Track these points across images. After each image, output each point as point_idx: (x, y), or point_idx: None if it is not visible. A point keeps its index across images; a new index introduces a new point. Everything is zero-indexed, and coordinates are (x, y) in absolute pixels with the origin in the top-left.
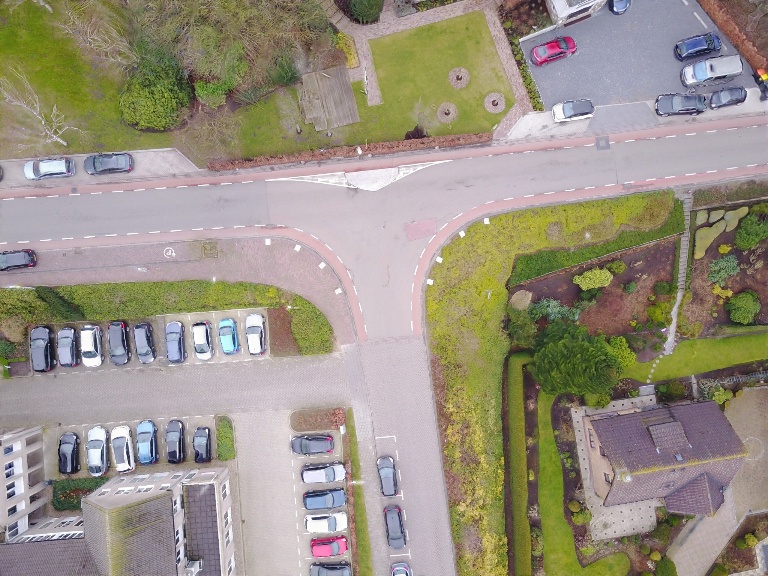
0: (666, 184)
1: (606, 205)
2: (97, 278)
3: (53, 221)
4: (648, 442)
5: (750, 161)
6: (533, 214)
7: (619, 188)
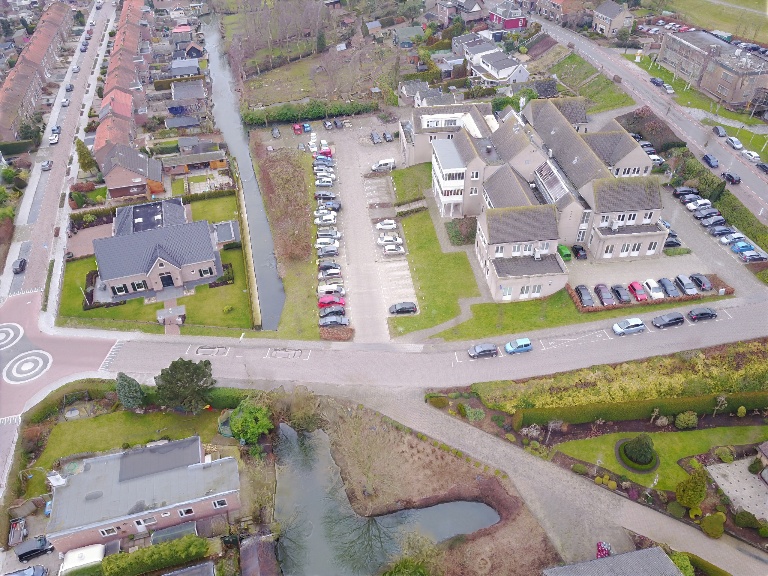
0: None
1: None
2: (742, 201)
3: (760, 188)
4: None
5: None
6: None
7: None
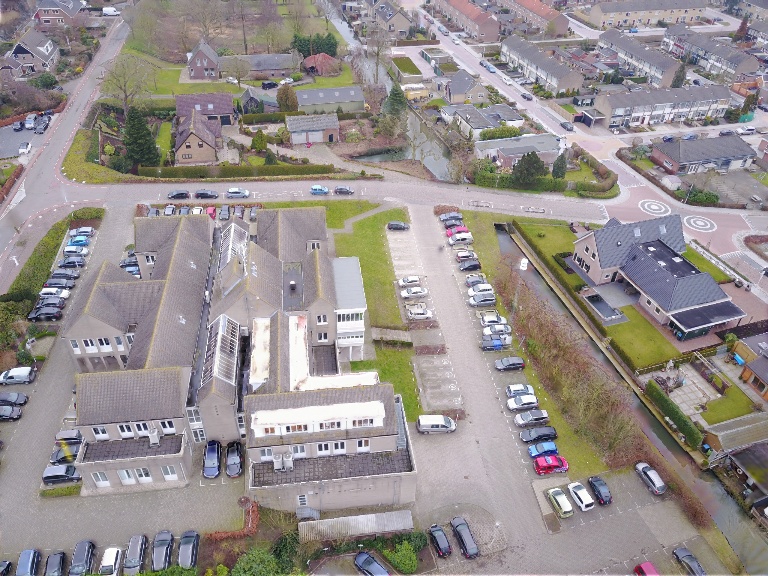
0: (75, 132)
1: (75, 142)
2: (10, 283)
3: None
4: (184, 132)
5: (78, 117)
6: (67, 157)
7: (70, 141)
